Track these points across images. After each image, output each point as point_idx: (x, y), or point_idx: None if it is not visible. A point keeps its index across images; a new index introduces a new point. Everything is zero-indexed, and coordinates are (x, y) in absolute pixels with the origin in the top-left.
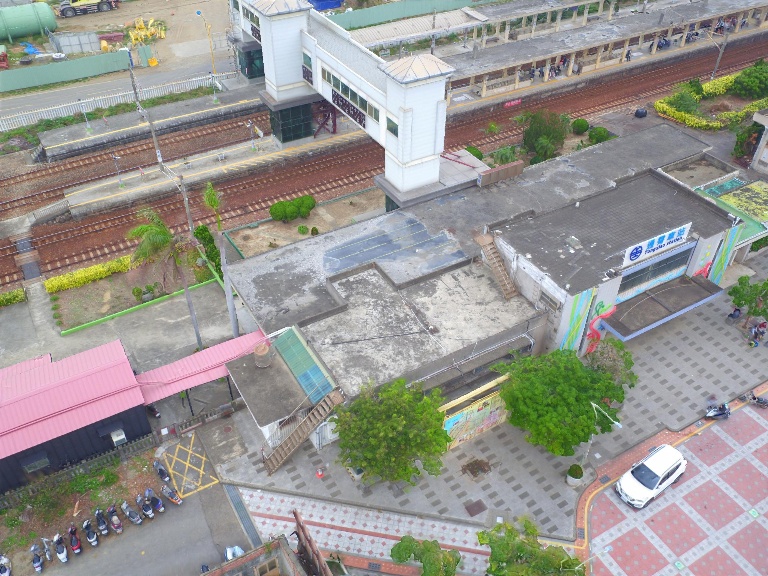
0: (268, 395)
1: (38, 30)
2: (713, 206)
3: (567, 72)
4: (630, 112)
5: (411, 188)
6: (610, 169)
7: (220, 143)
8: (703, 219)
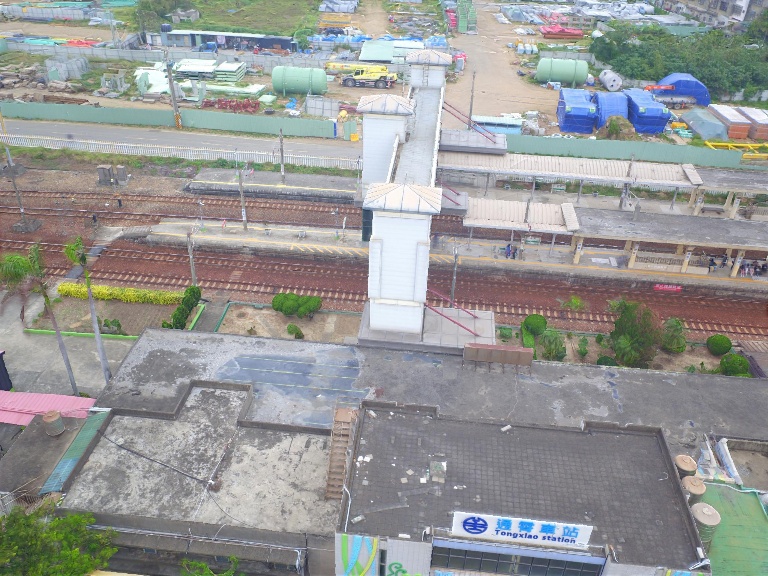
0: (22, 463)
1: (308, 90)
2: (692, 524)
3: None
4: None
5: (383, 328)
6: (659, 409)
7: (327, 223)
8: (658, 534)
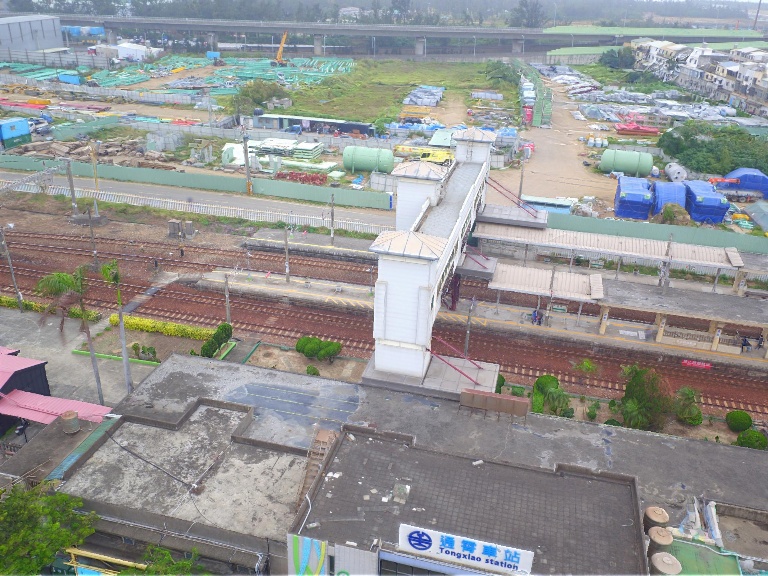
0: (37, 453)
1: None
2: (645, 568)
3: None
4: None
5: (387, 370)
6: (651, 469)
7: (366, 282)
8: (609, 574)
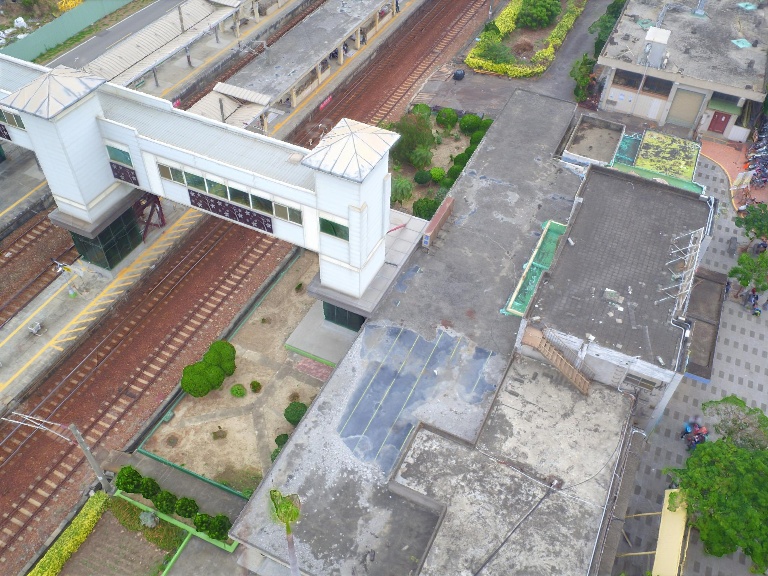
0: None
1: None
2: (679, 190)
3: (355, 45)
4: (446, 76)
5: (365, 287)
6: (520, 167)
7: (3, 300)
8: (681, 209)
